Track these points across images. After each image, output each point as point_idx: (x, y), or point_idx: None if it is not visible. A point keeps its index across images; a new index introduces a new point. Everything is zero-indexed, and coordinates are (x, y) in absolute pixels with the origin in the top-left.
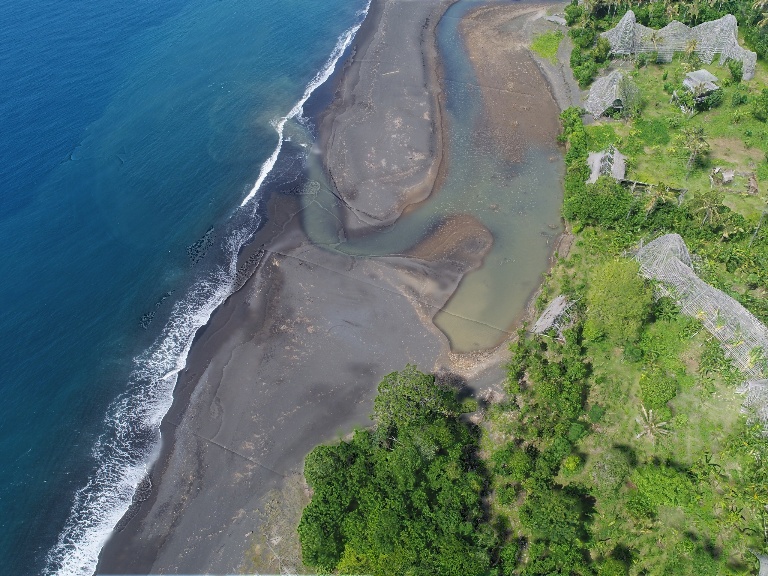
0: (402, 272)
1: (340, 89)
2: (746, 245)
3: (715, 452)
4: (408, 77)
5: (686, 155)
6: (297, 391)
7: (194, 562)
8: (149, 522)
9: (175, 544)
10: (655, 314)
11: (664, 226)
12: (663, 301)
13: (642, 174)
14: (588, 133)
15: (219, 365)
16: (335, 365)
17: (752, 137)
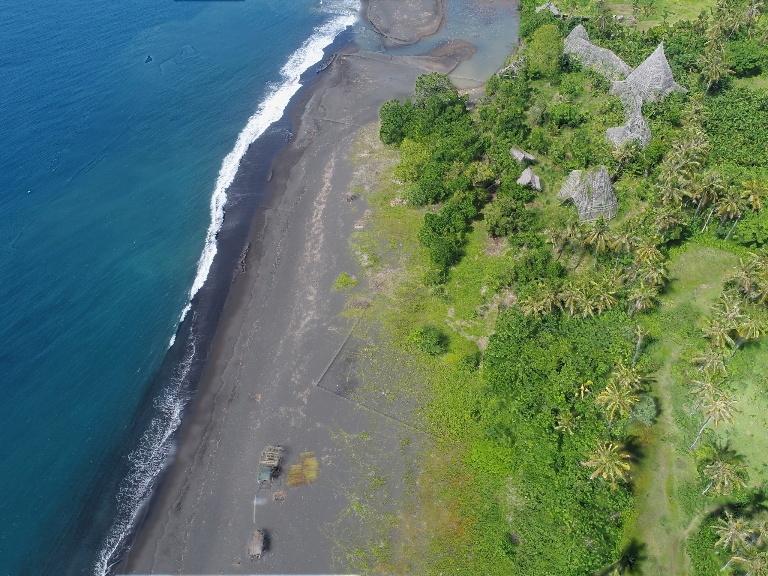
0: (422, 61)
1: None
2: None
3: (595, 114)
4: None
5: None
6: (367, 102)
7: (324, 152)
8: (295, 144)
9: (312, 148)
10: (569, 68)
11: None
12: None
13: None
14: (536, 2)
15: (319, 95)
16: (387, 93)
17: (639, 3)
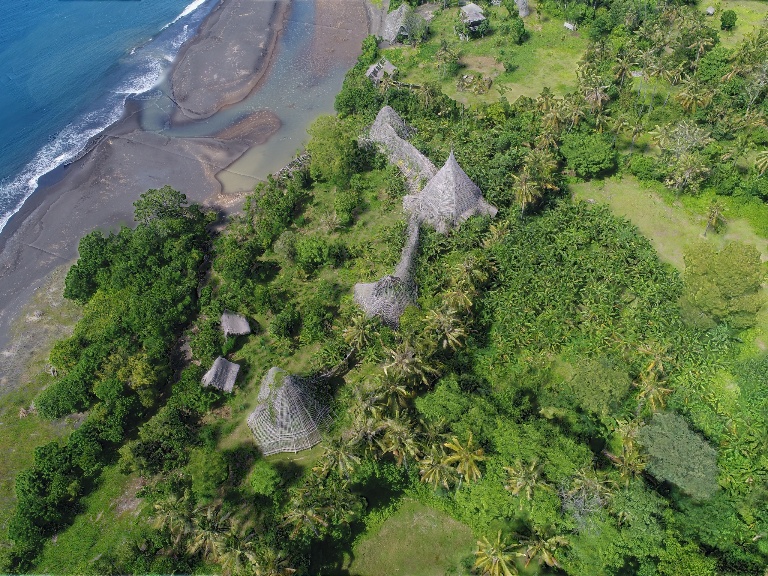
0: (203, 147)
1: (201, 28)
2: (460, 123)
3: (376, 242)
4: (257, 18)
5: (448, 68)
6: (100, 216)
7: None
8: None
9: None
10: (370, 164)
11: (400, 110)
12: (377, 155)
13: (408, 80)
14: (380, 54)
15: (48, 203)
16: (132, 201)
17: (505, 55)
